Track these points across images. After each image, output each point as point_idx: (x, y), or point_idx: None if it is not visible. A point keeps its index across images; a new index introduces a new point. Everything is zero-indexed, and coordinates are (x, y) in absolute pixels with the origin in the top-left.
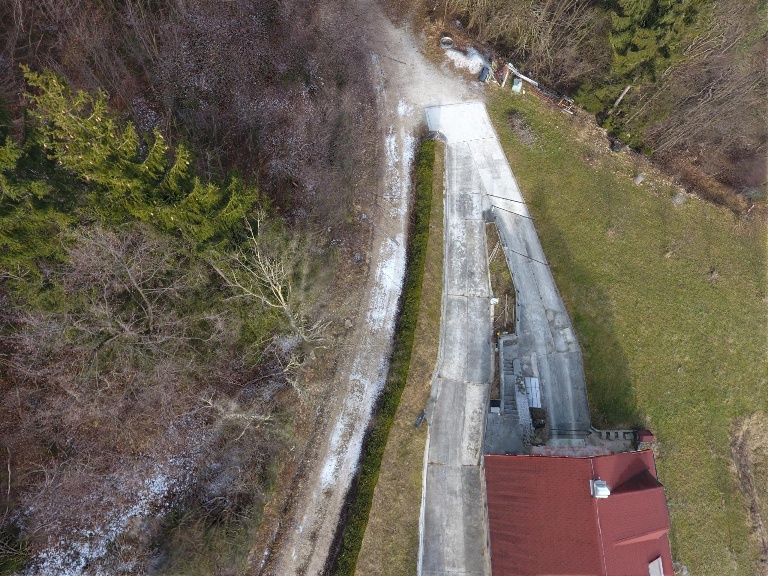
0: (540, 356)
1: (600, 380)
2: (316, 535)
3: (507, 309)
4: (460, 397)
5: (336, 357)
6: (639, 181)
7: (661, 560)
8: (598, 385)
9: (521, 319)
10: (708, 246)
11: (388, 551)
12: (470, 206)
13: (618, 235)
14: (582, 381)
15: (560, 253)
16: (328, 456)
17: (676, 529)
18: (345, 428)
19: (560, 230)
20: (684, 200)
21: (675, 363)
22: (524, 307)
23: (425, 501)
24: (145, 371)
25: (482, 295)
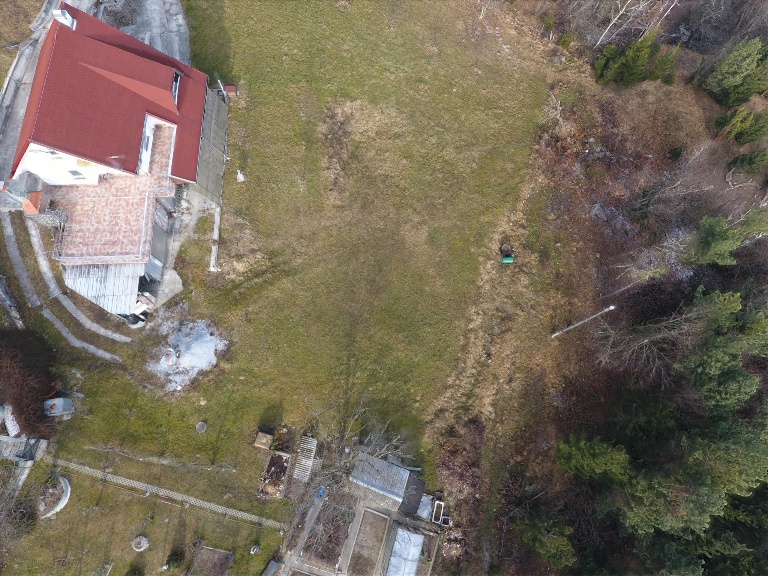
0: (154, 34)
1: (202, 52)
2: None
3: None
4: None
5: None
6: None
7: (176, 127)
8: (200, 55)
9: (142, 8)
10: None
11: None
12: None
13: None
14: (188, 53)
15: None
16: None
17: (249, 156)
18: None
19: None
20: None
21: (282, 52)
22: None
23: (2, 96)
24: None
25: None
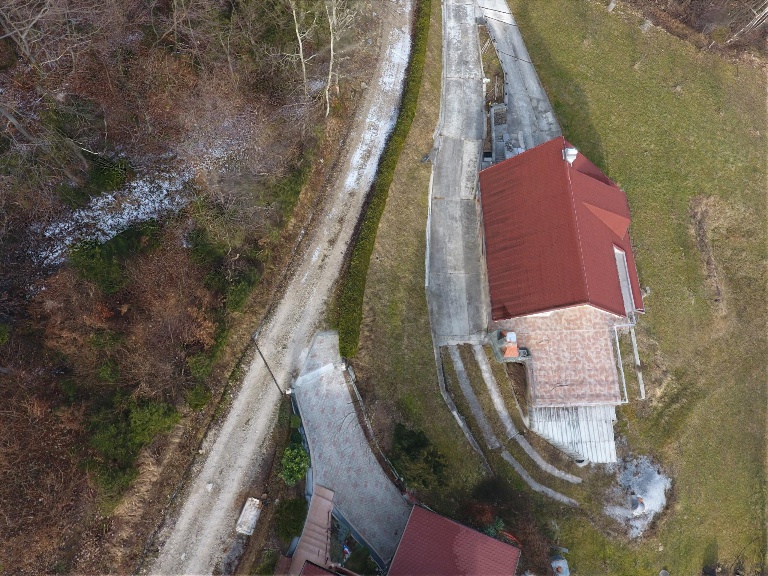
0: (526, 134)
1: None
2: (343, 219)
3: (497, 86)
4: (458, 150)
5: (354, 108)
6: (611, 8)
7: (625, 254)
8: None
9: (509, 105)
10: (672, 67)
11: (401, 242)
12: (465, 14)
13: (592, 46)
14: None
15: (542, 54)
16: (351, 171)
17: (642, 268)
18: (364, 153)
19: (542, 37)
20: (651, 30)
21: (642, 148)
22: (512, 96)
23: None
24: (203, 80)
25: (476, 77)
